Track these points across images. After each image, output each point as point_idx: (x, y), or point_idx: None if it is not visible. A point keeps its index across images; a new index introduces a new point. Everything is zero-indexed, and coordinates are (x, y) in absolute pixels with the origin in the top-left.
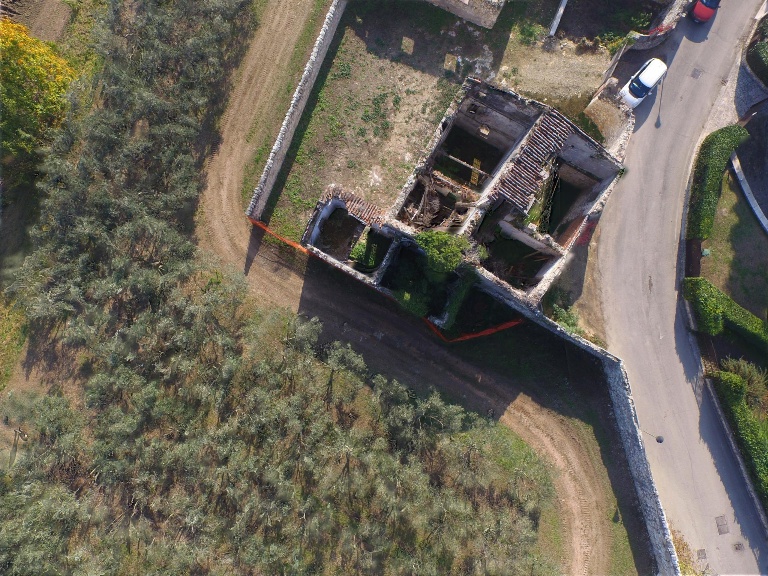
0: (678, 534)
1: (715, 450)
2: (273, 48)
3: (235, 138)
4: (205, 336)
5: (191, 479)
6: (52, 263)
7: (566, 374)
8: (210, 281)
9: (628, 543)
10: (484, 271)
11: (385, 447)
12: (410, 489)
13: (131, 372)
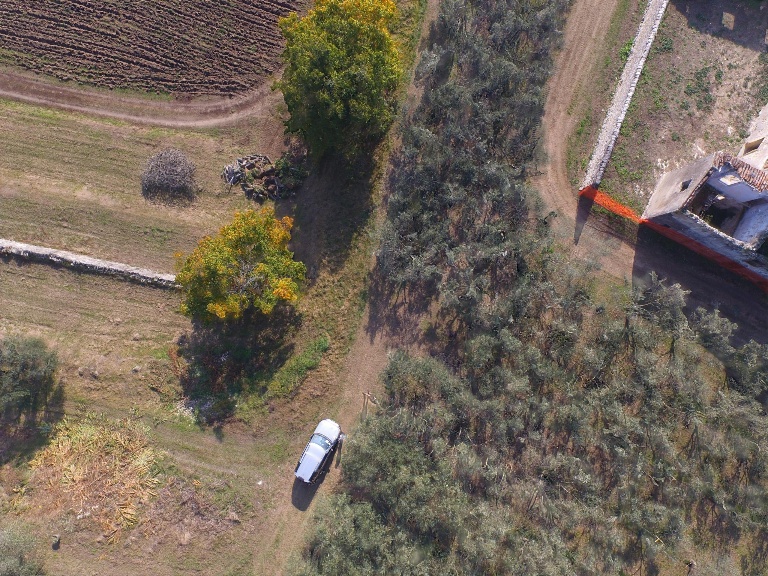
0: None
1: None
2: (589, 23)
3: (557, 110)
4: (543, 303)
5: None
6: (411, 229)
7: None
8: (543, 250)
9: None
10: None
11: (737, 413)
12: (760, 455)
13: (511, 334)
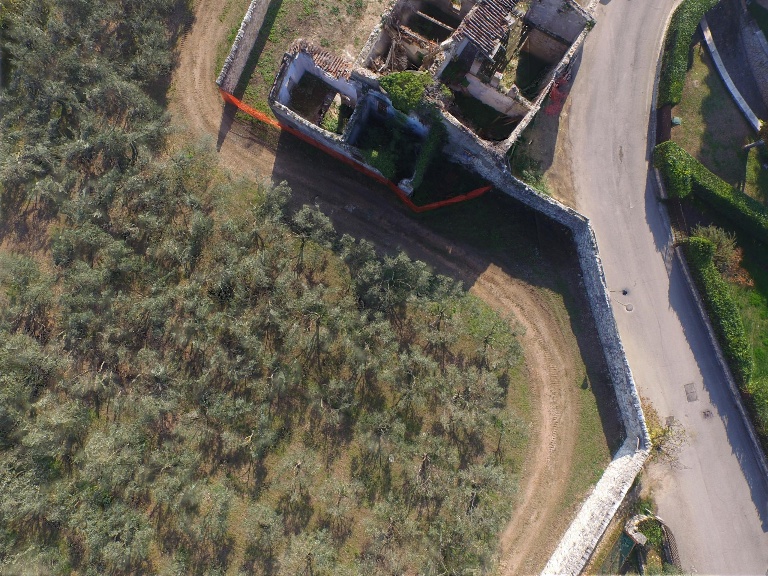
0: (647, 401)
1: (684, 318)
2: None
3: (208, 18)
4: (176, 209)
5: (157, 332)
6: None
7: (536, 244)
8: (182, 156)
9: (596, 409)
10: (449, 115)
11: (354, 314)
12: (379, 356)
13: (99, 229)
